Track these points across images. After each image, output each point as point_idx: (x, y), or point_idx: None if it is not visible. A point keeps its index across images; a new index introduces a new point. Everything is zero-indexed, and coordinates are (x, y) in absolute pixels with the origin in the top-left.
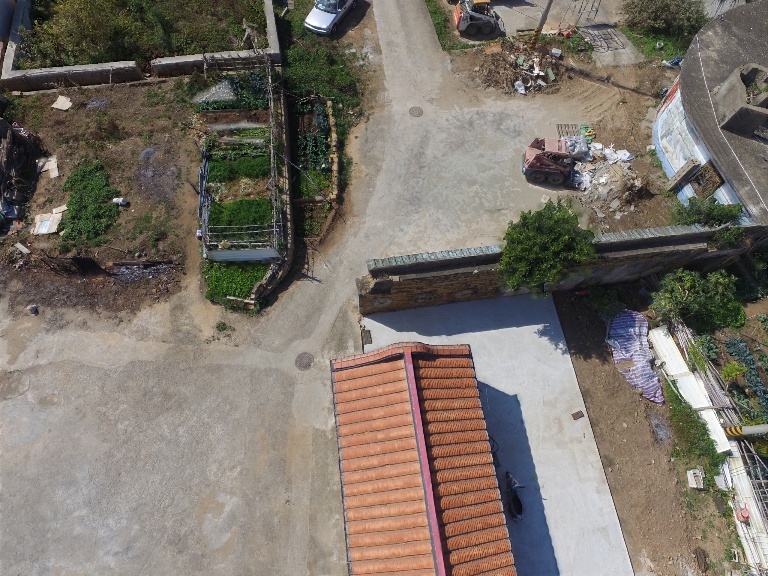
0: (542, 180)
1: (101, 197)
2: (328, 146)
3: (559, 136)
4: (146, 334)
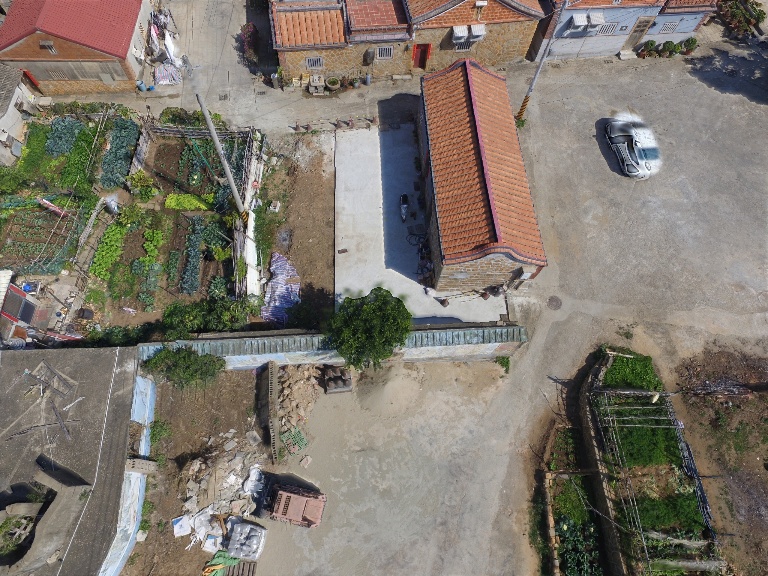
0: None
1: None
2: (563, 567)
3: (256, 568)
4: (689, 332)
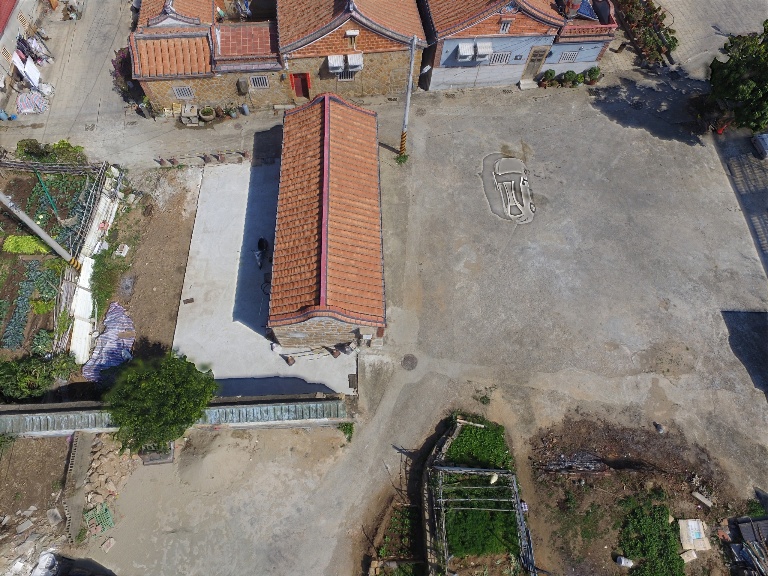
0: (99, 575)
1: (648, 569)
2: None
3: None
4: (551, 397)
